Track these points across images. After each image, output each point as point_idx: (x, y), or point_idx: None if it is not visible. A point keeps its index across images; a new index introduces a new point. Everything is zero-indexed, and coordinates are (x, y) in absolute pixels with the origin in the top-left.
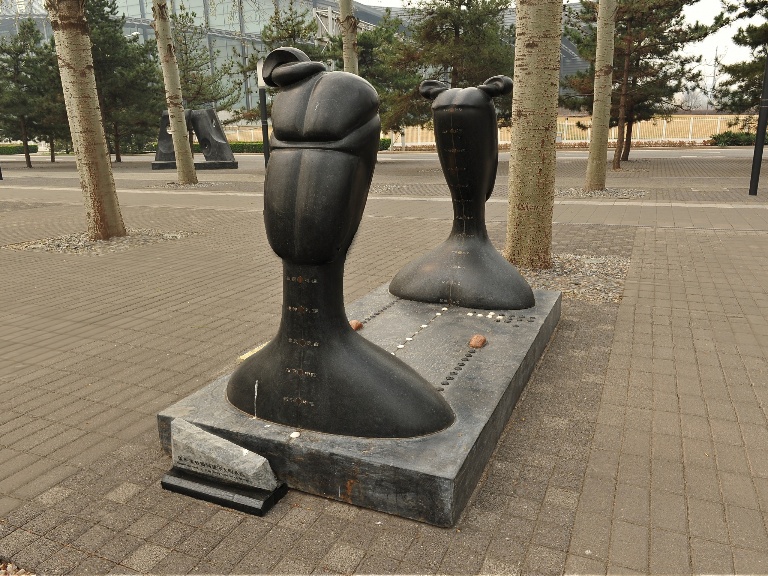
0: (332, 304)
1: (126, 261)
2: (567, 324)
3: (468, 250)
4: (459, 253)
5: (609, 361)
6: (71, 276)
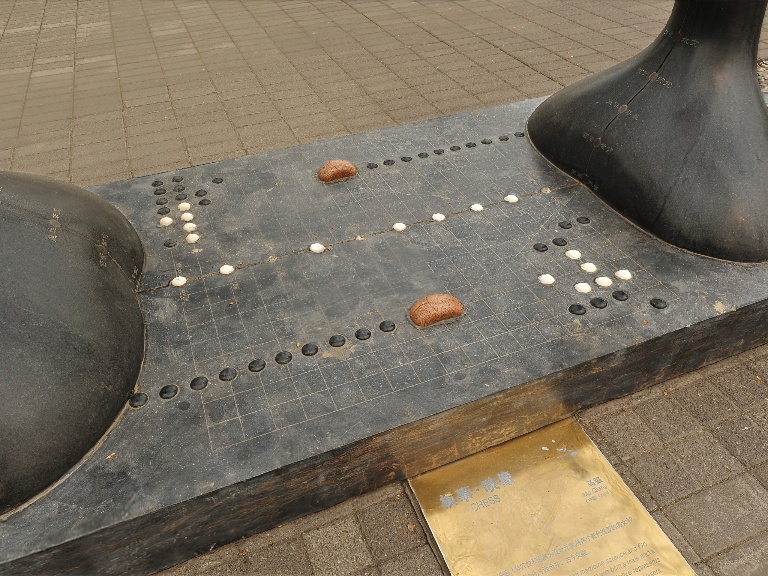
0: None
1: None
2: None
3: None
4: None
5: None
6: None
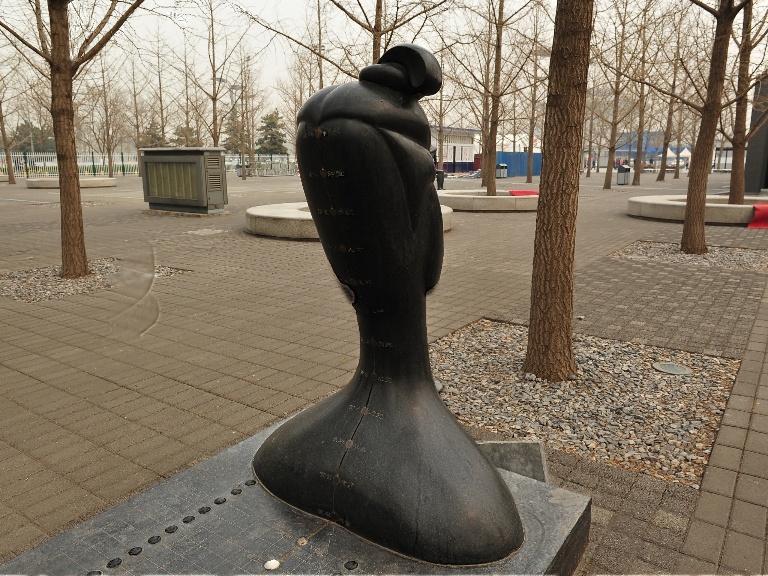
0: None
1: None
2: None
3: None
4: None
5: None
6: None
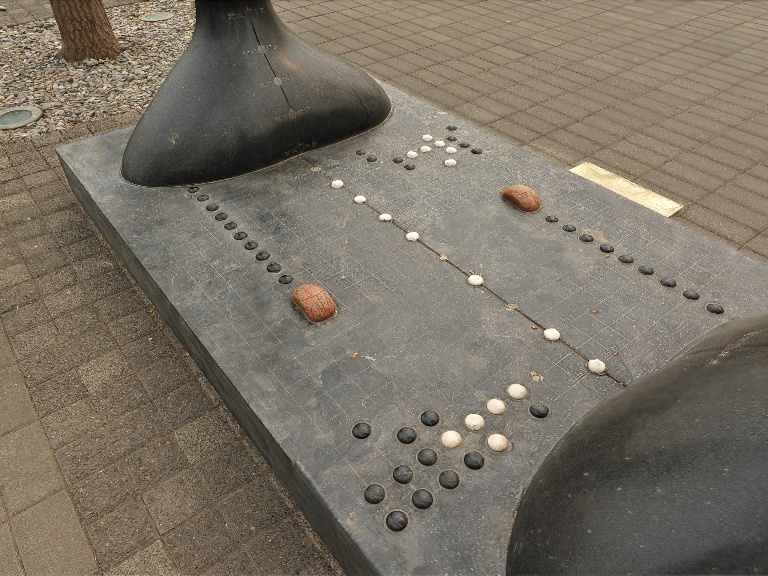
0: None
1: None
2: None
3: None
4: None
5: None
6: None
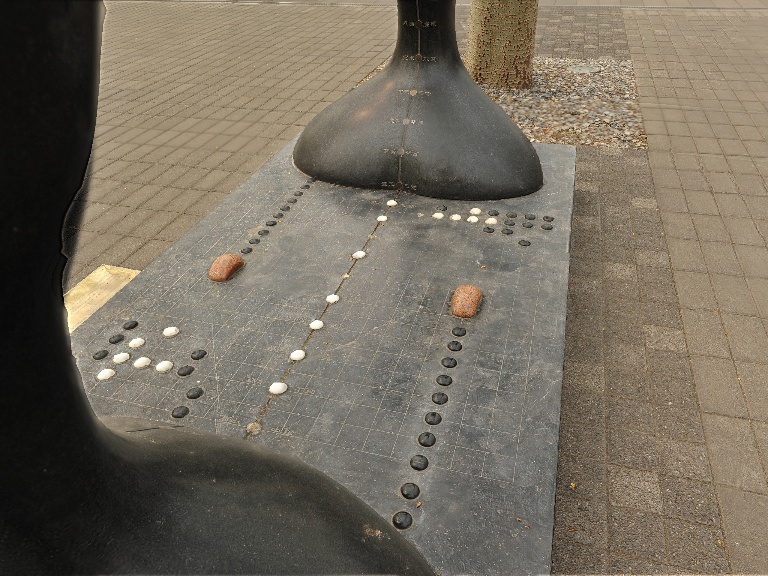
0: (27, 485)
1: None
2: (583, 201)
3: (427, 87)
4: (411, 94)
5: (676, 289)
6: None
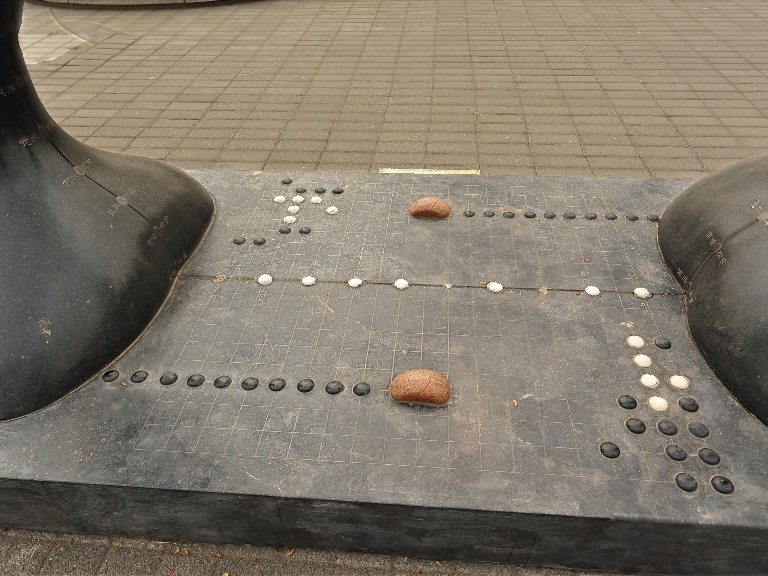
0: None
1: (662, 1)
2: None
3: None
4: None
5: None
6: (569, 3)
